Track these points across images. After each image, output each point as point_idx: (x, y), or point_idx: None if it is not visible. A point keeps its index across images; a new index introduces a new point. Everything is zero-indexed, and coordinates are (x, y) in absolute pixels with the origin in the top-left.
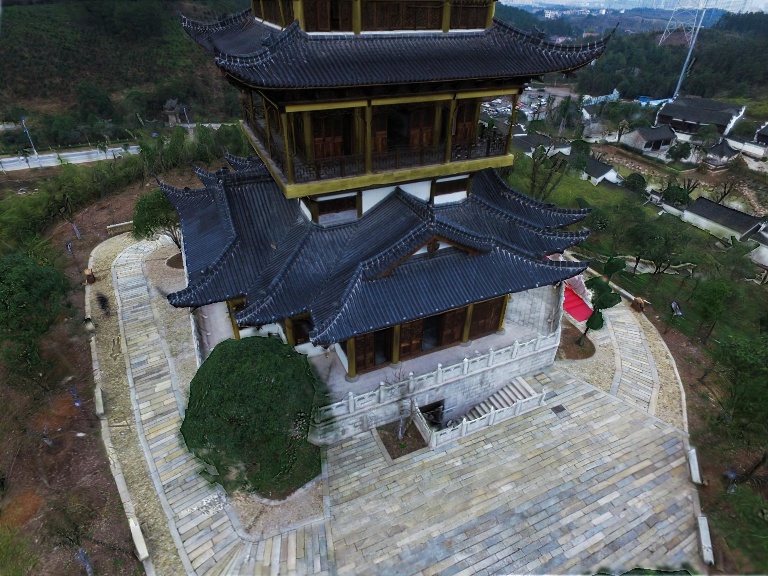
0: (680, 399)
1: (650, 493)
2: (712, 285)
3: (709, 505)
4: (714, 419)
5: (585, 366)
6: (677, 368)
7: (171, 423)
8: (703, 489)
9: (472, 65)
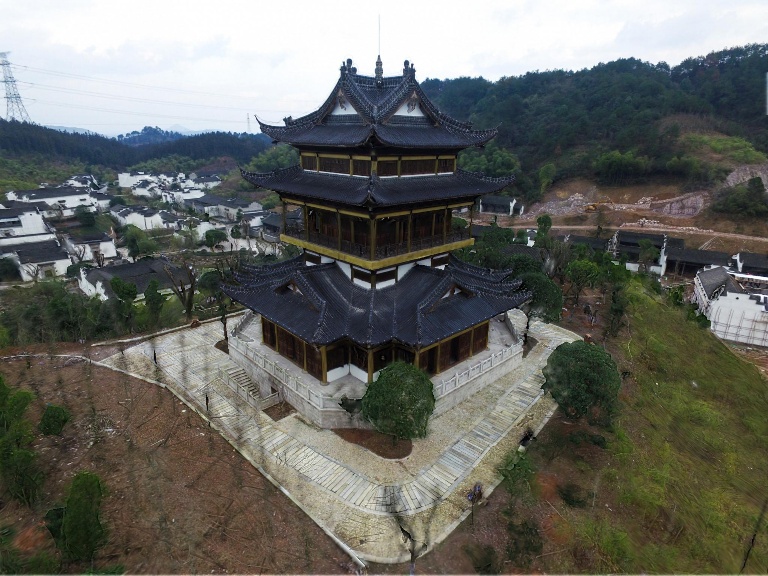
0: None
1: None
2: None
3: None
4: None
5: None
6: None
7: (540, 372)
8: None
9: None
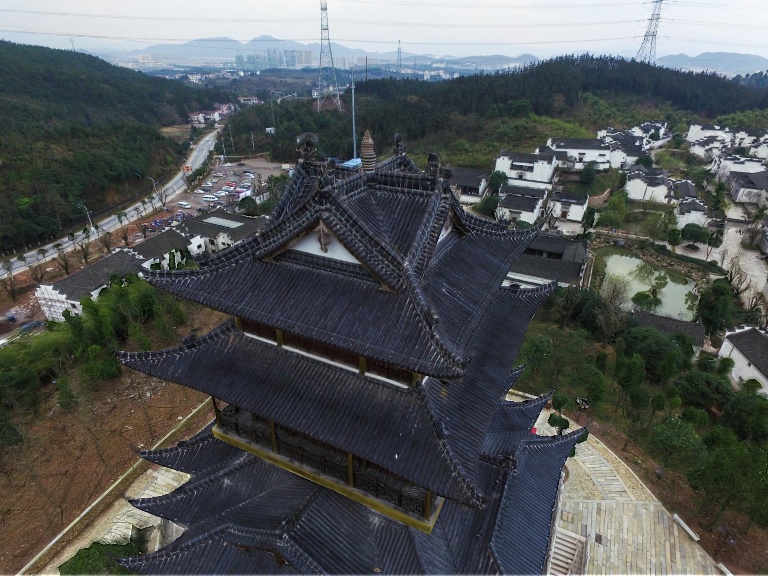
0: (633, 475)
1: (689, 568)
2: (584, 373)
3: (711, 551)
4: (657, 479)
5: (574, 485)
6: (608, 448)
7: None
8: (700, 541)
9: (507, 337)
